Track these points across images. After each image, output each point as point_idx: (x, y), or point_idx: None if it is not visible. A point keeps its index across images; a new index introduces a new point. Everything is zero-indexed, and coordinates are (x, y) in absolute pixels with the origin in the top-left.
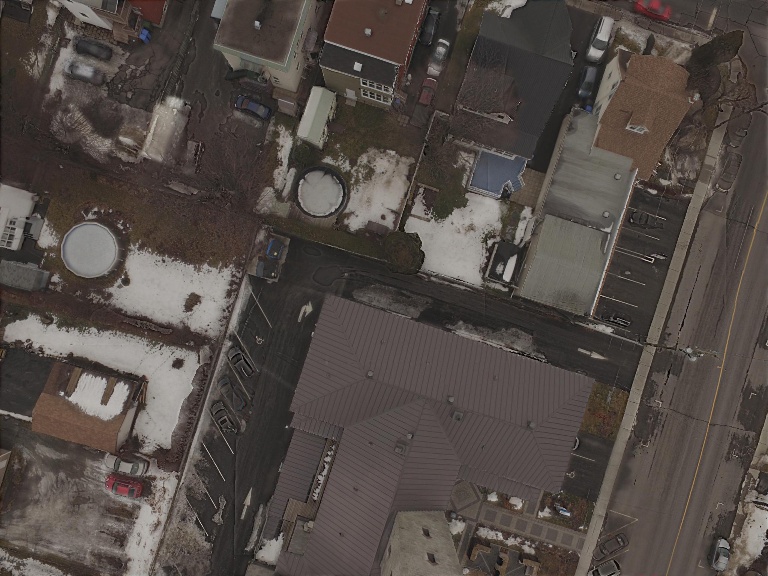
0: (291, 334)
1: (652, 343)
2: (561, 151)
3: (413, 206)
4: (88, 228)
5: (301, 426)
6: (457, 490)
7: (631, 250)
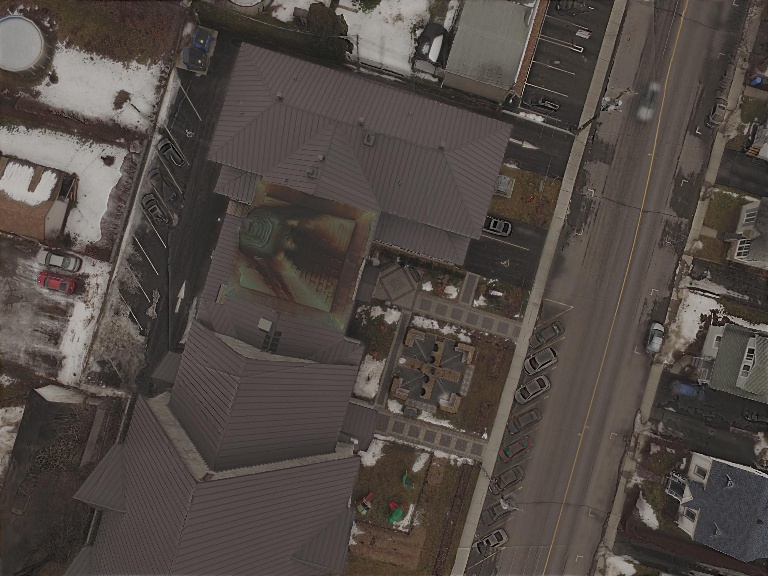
0: None
1: (583, 131)
2: None
3: None
4: (13, 22)
5: (225, 191)
6: (392, 280)
7: (560, 39)
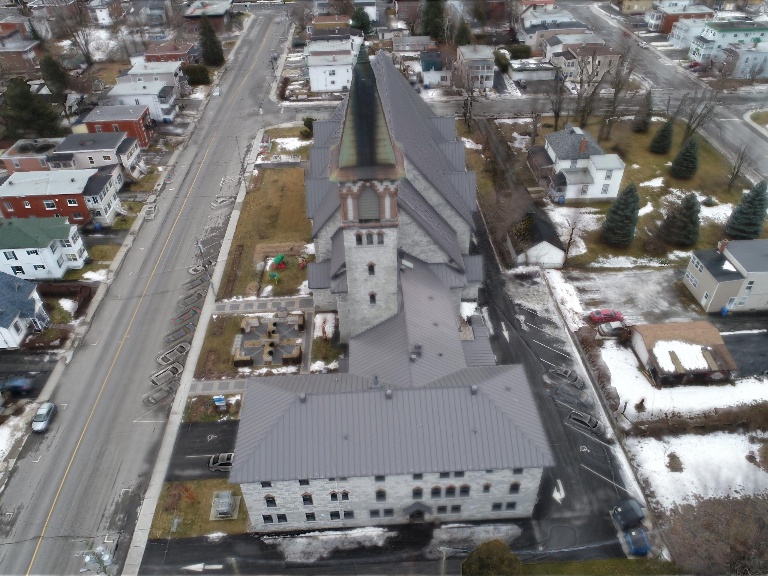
0: (558, 465)
1: None
2: None
3: None
4: None
5: None
6: None
7: None
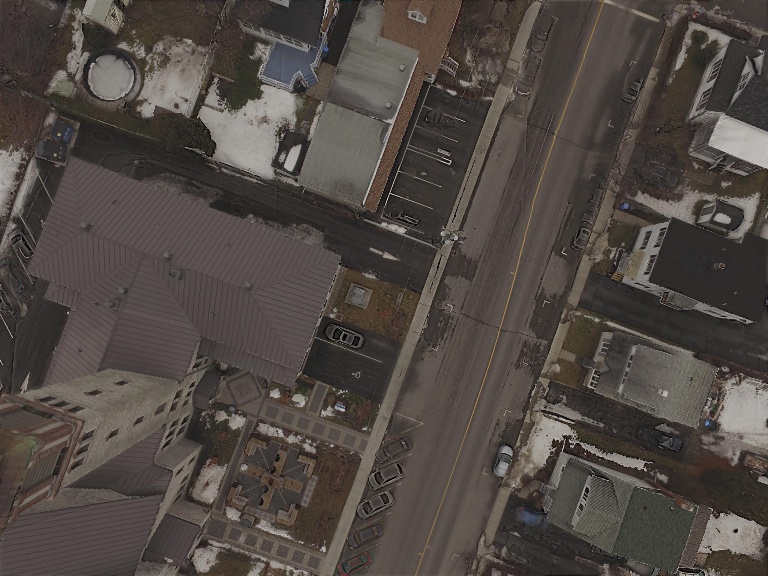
0: None
1: (445, 245)
2: (348, 41)
3: (207, 96)
4: None
5: (54, 298)
6: (239, 385)
7: (428, 151)
